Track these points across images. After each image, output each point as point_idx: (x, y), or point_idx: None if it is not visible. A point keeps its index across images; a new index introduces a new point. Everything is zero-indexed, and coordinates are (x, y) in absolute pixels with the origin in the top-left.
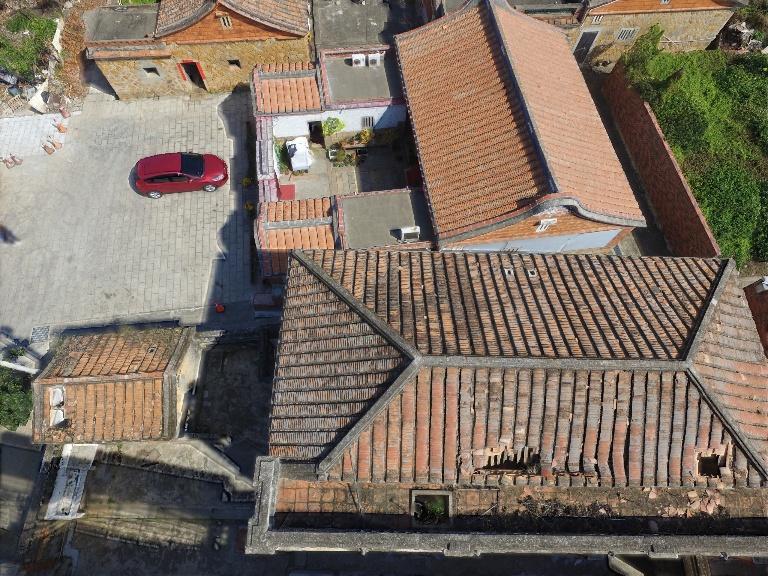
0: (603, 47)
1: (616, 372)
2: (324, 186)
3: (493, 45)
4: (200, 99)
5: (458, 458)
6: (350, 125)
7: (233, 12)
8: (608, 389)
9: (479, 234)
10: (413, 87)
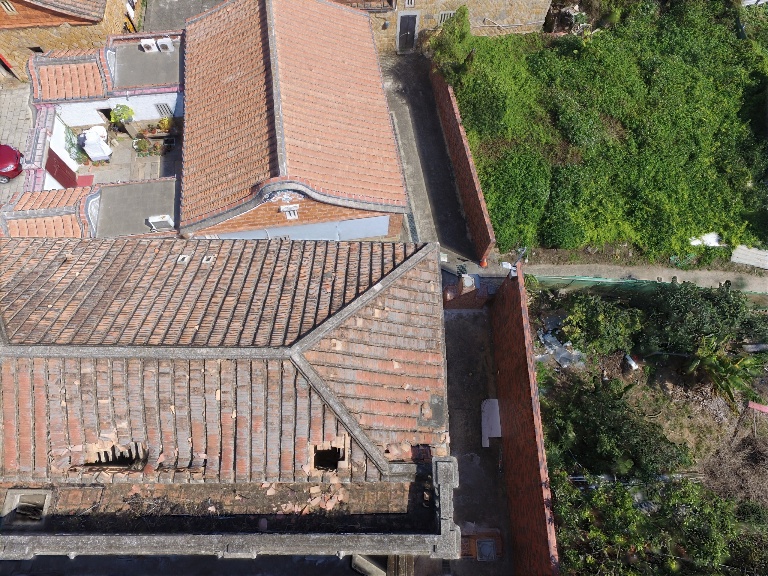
0: (429, 32)
1: (218, 361)
2: (124, 176)
3: (264, 27)
4: (12, 89)
5: (48, 455)
6: (146, 113)
7: None
8: (209, 379)
9: (217, 221)
10: (192, 72)
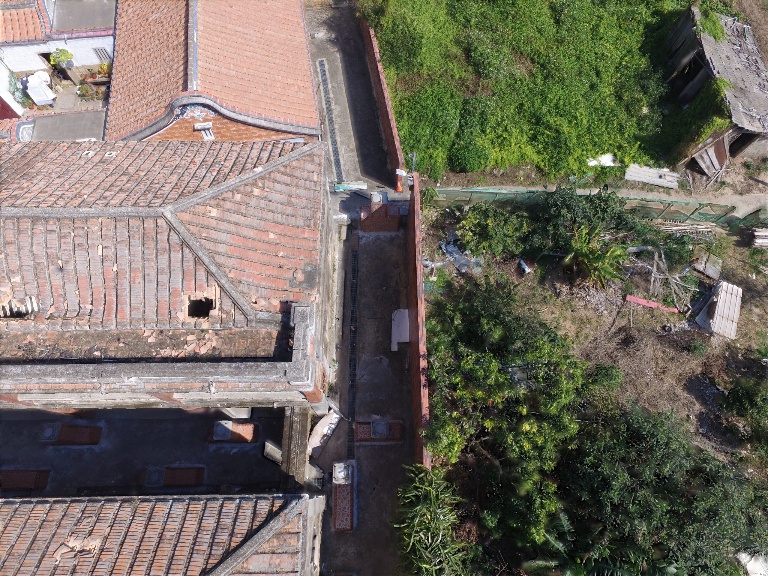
0: None
1: (100, 219)
2: None
3: None
4: None
5: None
6: (86, 58)
7: None
8: (92, 235)
9: (136, 139)
10: (123, 13)
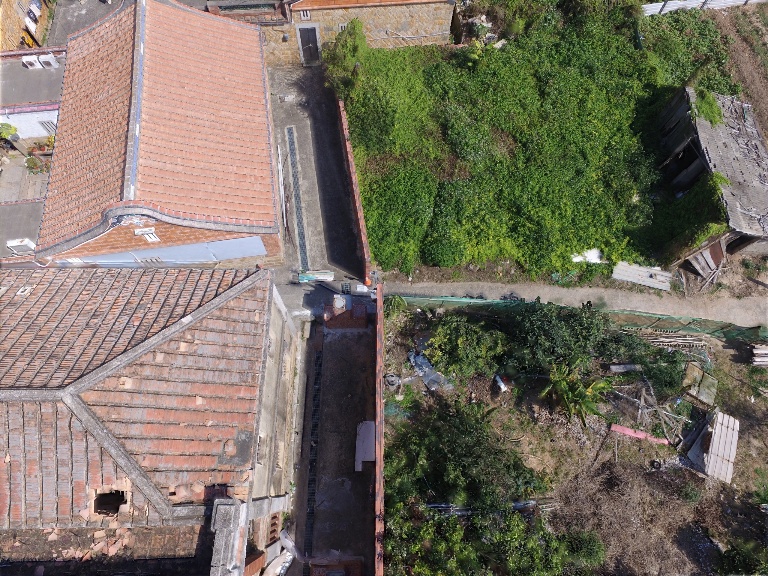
0: (332, 44)
1: None
2: (13, 195)
3: None
4: None
5: None
6: (32, 130)
7: None
8: None
9: (70, 246)
10: (67, 89)
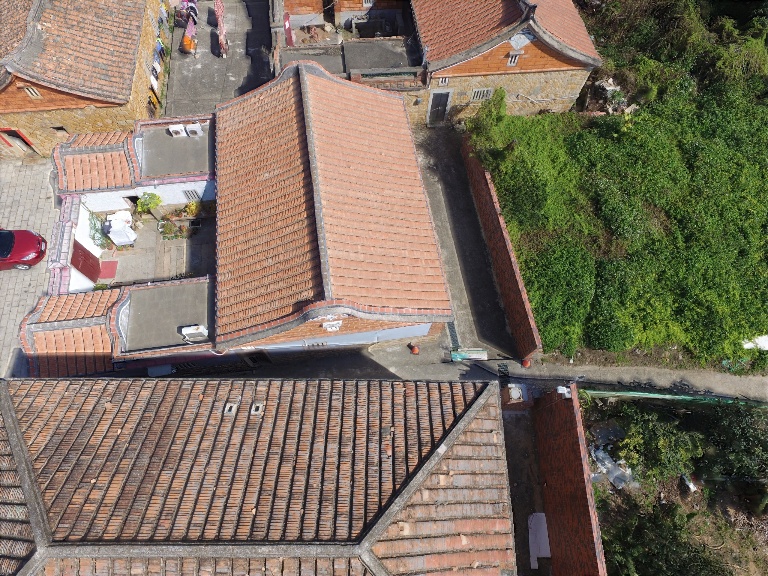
0: (460, 106)
1: (280, 558)
2: (149, 262)
3: (300, 122)
4: (33, 164)
5: None
6: (173, 198)
7: (36, 83)
8: None
9: (256, 339)
10: (223, 164)
